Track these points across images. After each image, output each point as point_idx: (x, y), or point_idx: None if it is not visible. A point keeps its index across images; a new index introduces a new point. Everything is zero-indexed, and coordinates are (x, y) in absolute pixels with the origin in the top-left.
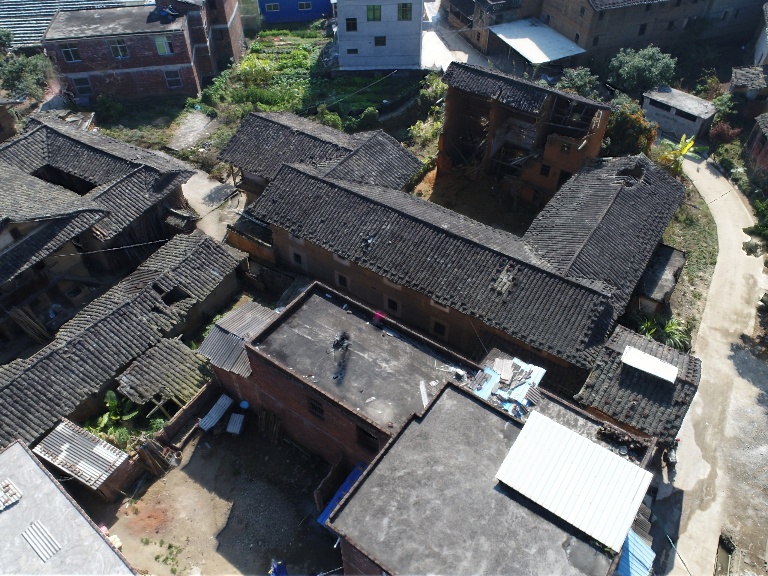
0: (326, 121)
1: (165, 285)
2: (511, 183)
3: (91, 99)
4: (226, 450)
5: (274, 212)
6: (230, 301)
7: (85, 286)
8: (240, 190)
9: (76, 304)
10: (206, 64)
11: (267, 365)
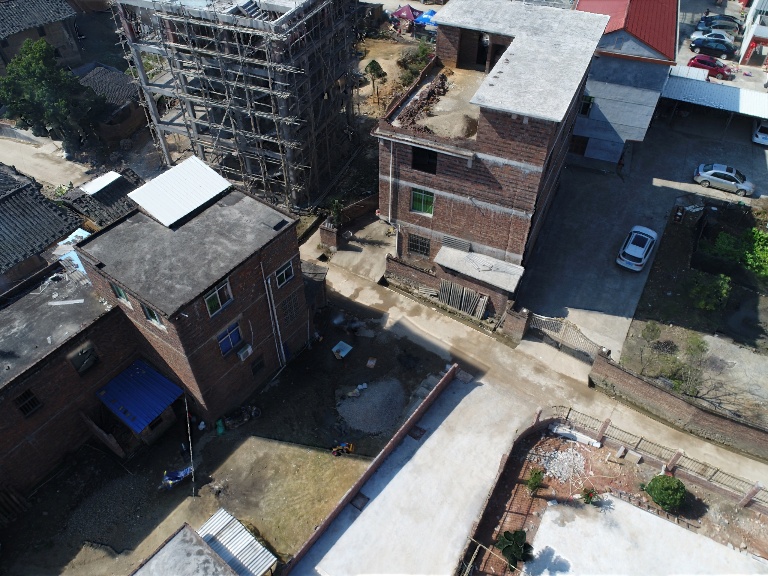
0: None
1: None
2: None
3: None
4: (14, 563)
5: None
6: None
7: None
8: None
9: None
10: None
11: None
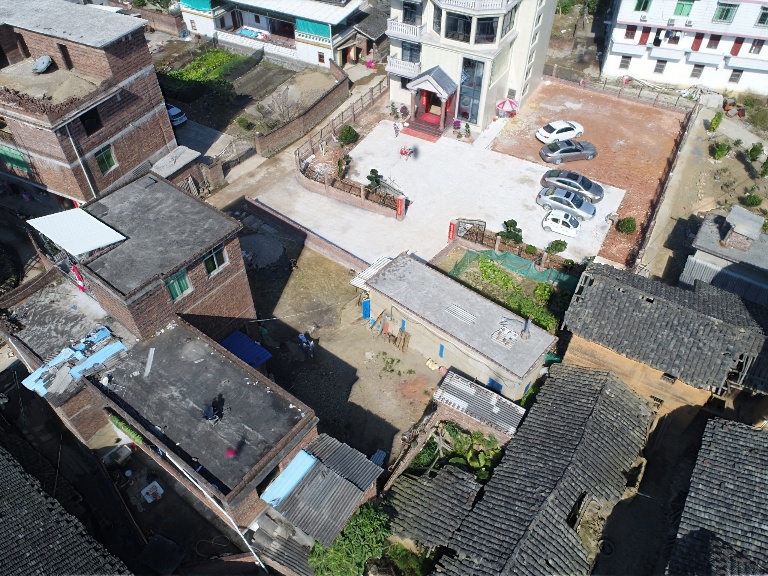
0: None
1: None
2: None
3: None
4: (361, 448)
5: None
6: None
7: None
8: None
9: None
10: None
11: None
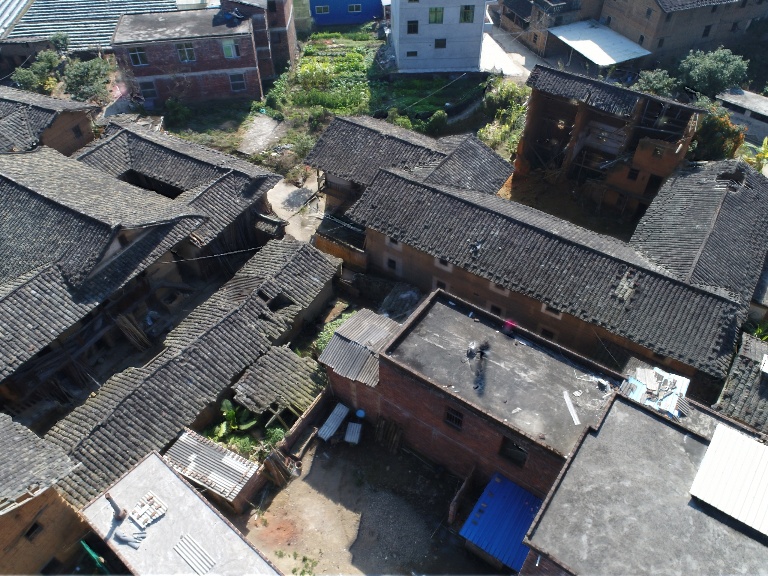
0: (397, 124)
1: (269, 292)
2: (594, 187)
3: (155, 103)
4: (345, 460)
5: (374, 218)
6: (326, 307)
7: (180, 292)
8: (317, 194)
9: (172, 311)
10: (266, 67)
11: (402, 375)
